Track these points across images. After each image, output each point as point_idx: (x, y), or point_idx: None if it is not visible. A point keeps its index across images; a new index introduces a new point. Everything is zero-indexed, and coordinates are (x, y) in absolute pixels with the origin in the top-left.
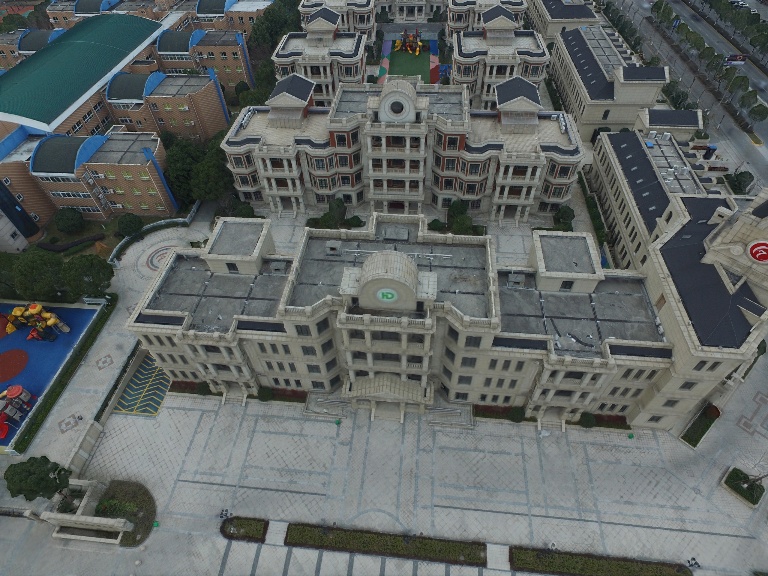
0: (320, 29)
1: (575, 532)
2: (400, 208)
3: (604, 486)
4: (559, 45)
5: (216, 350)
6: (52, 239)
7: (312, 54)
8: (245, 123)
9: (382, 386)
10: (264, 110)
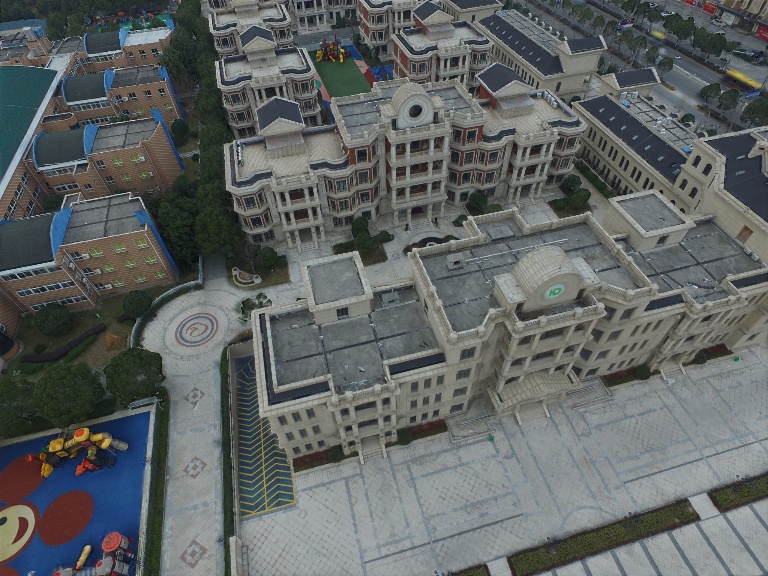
0: (259, 49)
1: (747, 458)
2: (419, 213)
3: (743, 409)
4: (483, 32)
5: (368, 406)
6: (37, 348)
7: (261, 76)
8: (241, 159)
9: (538, 386)
10: (252, 142)
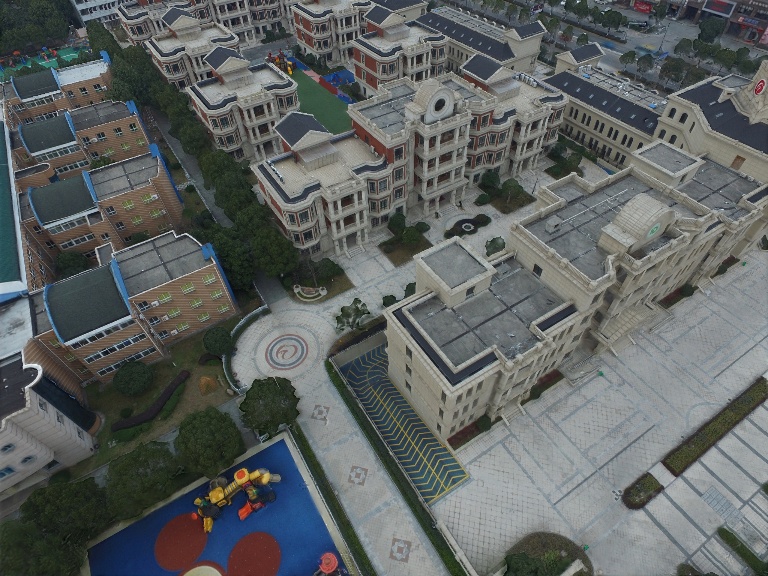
0: (232, 69)
1: None
2: (442, 200)
3: (766, 300)
4: None
5: (525, 366)
6: (124, 412)
7: (244, 96)
8: None
9: (634, 317)
10: (279, 159)
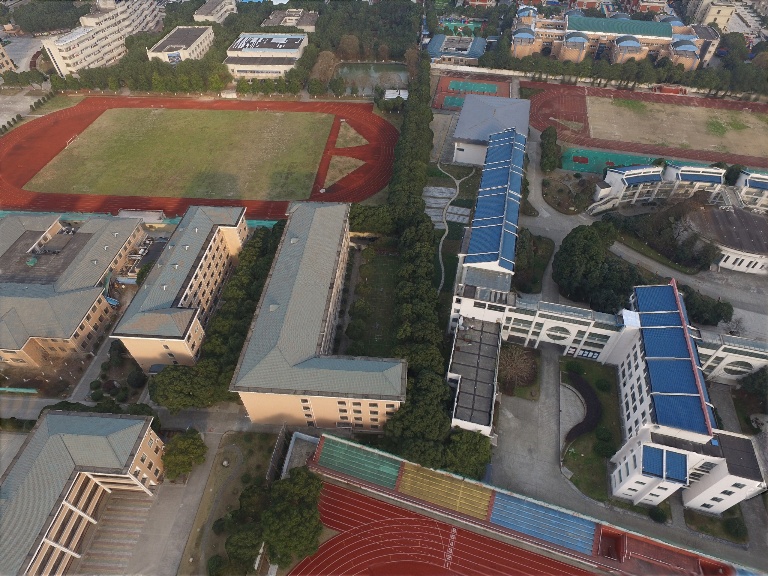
0: None
1: None
2: None
3: None
4: None
5: None
6: None
7: None
8: None
9: None
10: None
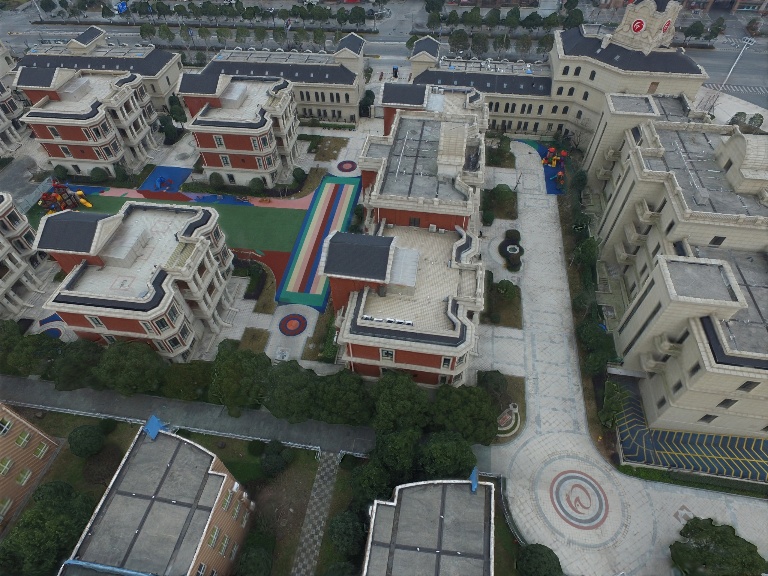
0: (108, 237)
1: None
2: None
3: None
4: None
5: None
6: None
7: (166, 262)
8: None
9: None
10: None
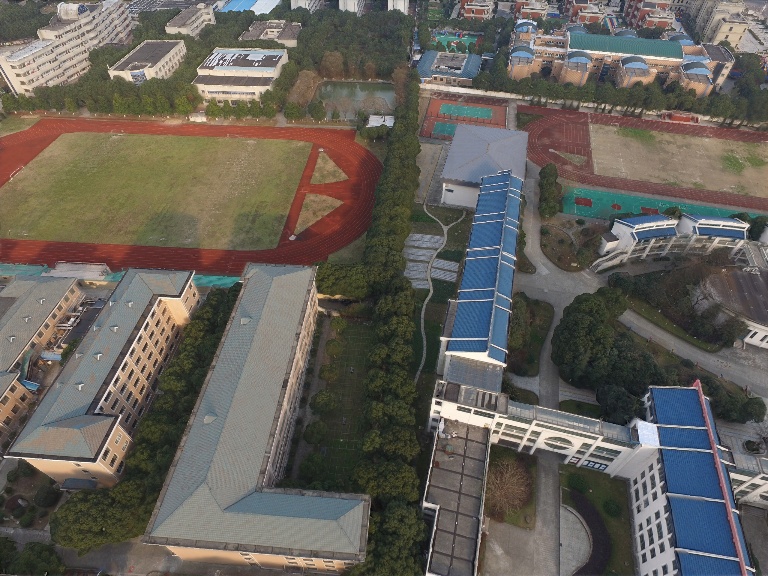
0: None
1: None
2: None
3: None
4: None
5: None
6: None
7: None
8: None
9: None
10: None
